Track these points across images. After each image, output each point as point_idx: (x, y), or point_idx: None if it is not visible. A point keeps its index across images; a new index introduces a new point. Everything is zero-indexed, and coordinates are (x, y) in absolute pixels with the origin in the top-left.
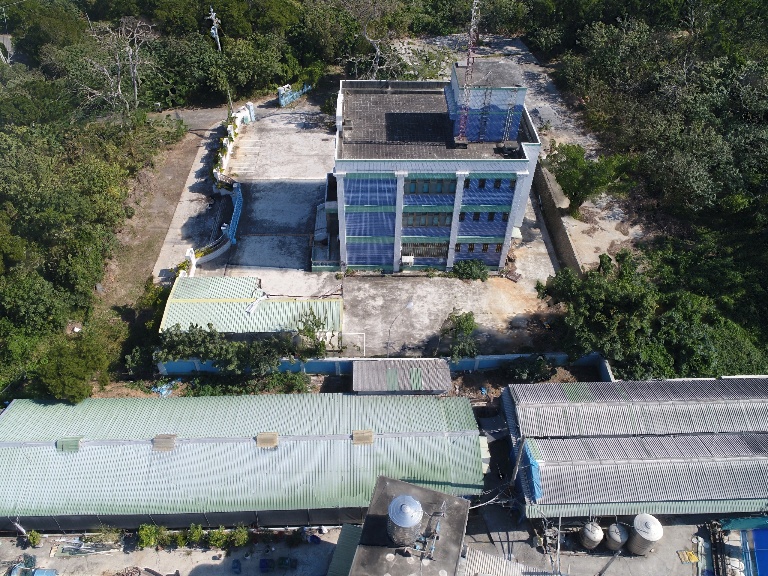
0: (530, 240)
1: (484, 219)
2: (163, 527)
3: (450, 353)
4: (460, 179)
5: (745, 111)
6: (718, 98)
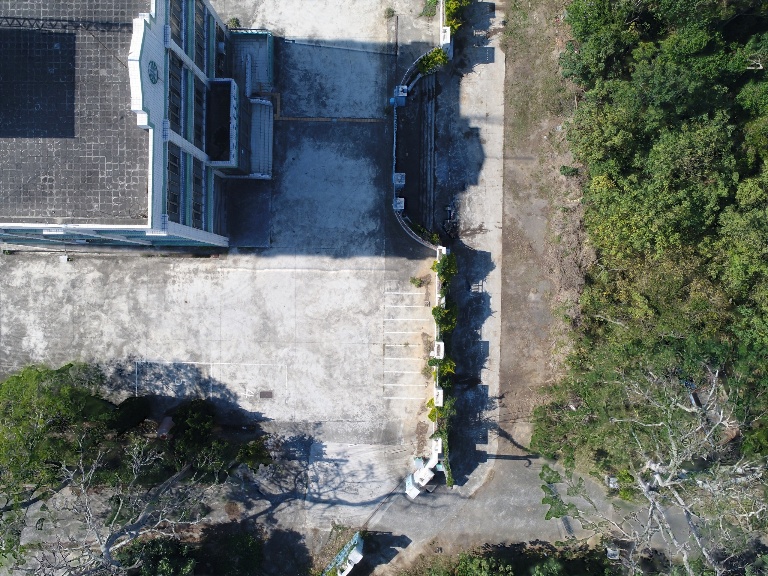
0: None
1: None
2: None
3: None
4: None
5: None
6: None
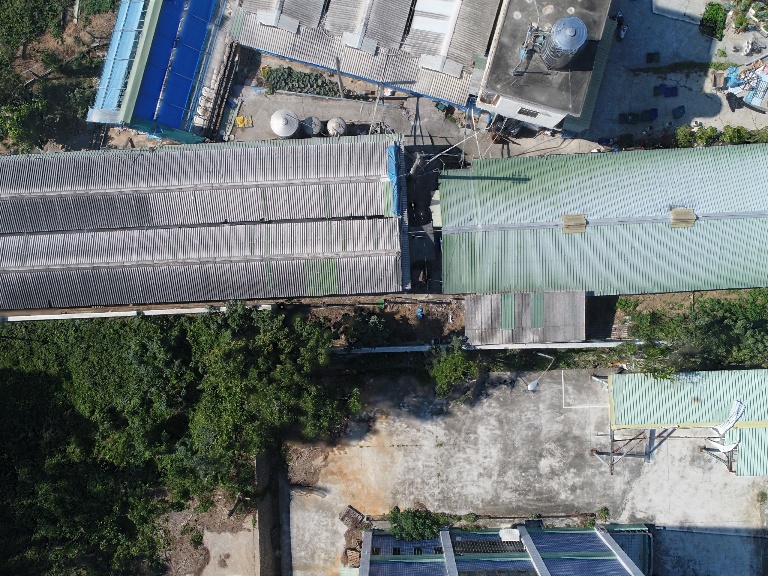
0: None
1: None
2: (764, 140)
3: None
4: None
5: None
6: None
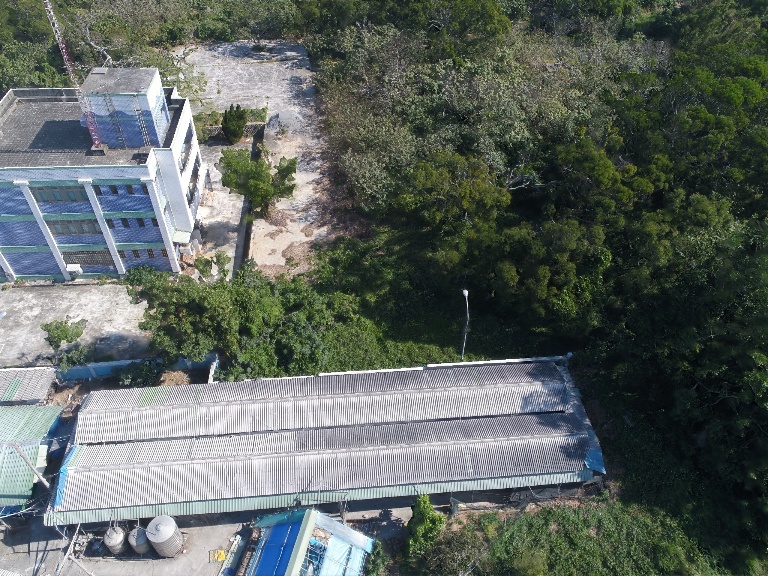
0: (222, 244)
1: (135, 225)
2: None
3: (60, 362)
4: (86, 186)
5: (461, 112)
6: (436, 99)
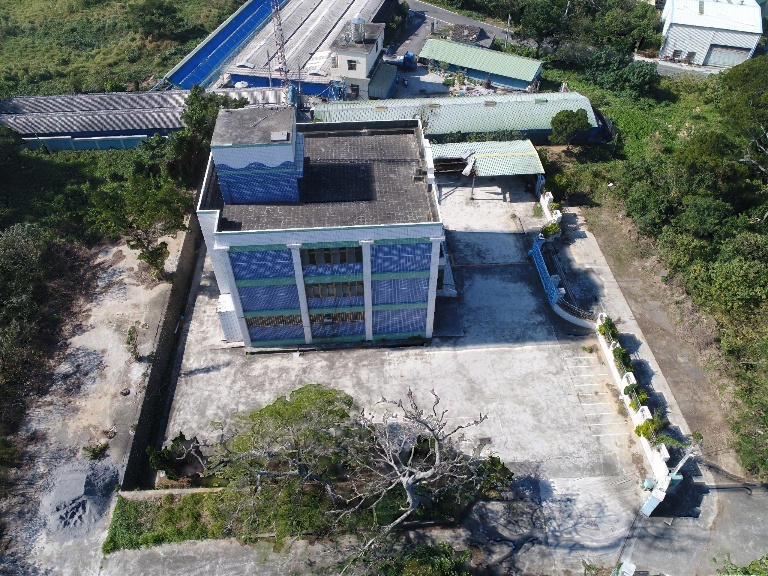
0: None
1: None
2: None
3: None
4: None
5: None
6: None
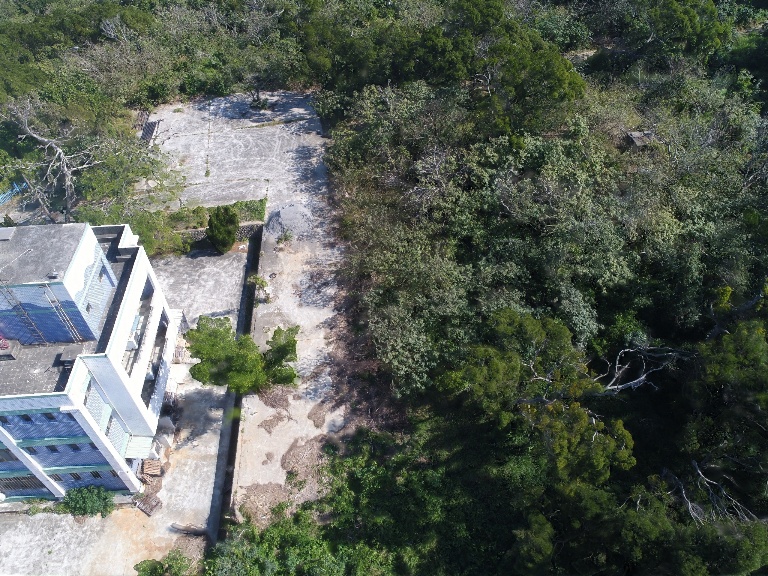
0: (202, 432)
1: (66, 450)
2: None
3: None
4: None
5: None
6: None
